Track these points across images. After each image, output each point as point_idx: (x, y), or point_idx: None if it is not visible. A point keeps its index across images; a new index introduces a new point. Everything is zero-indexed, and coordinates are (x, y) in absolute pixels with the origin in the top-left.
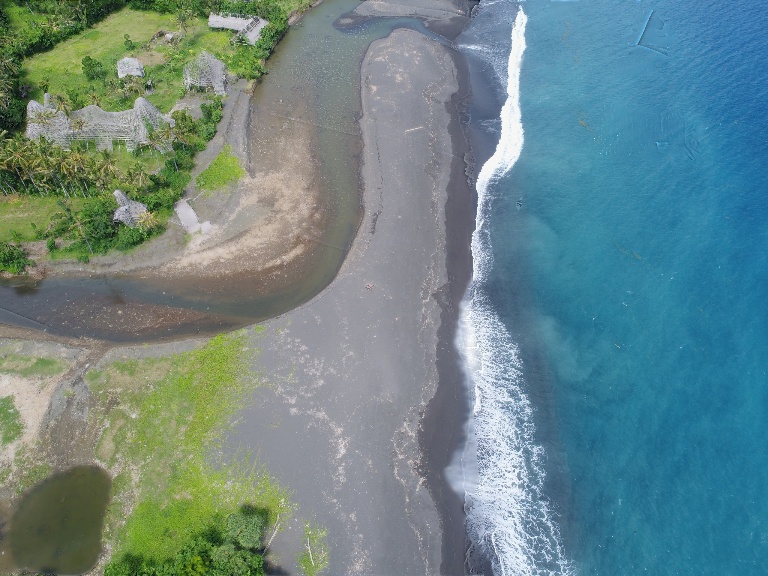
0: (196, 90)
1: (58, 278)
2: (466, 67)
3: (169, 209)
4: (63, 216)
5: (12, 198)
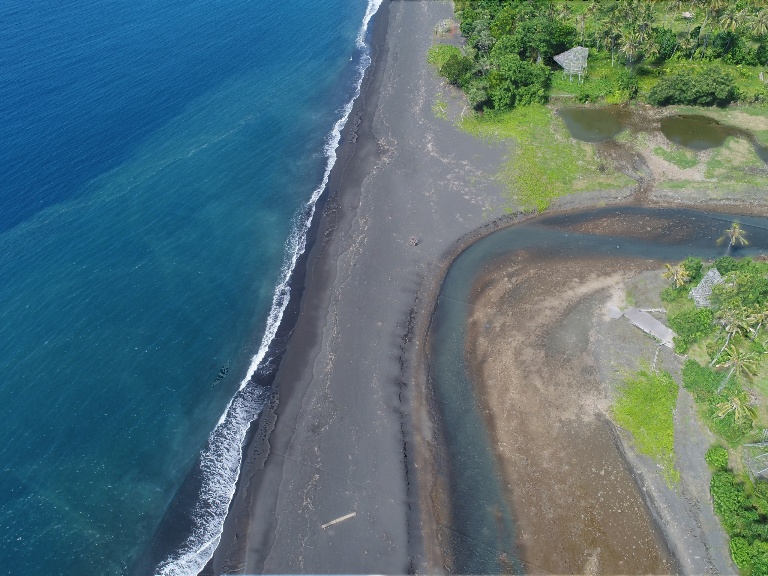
0: None
1: None
2: None
3: None
4: None
5: None
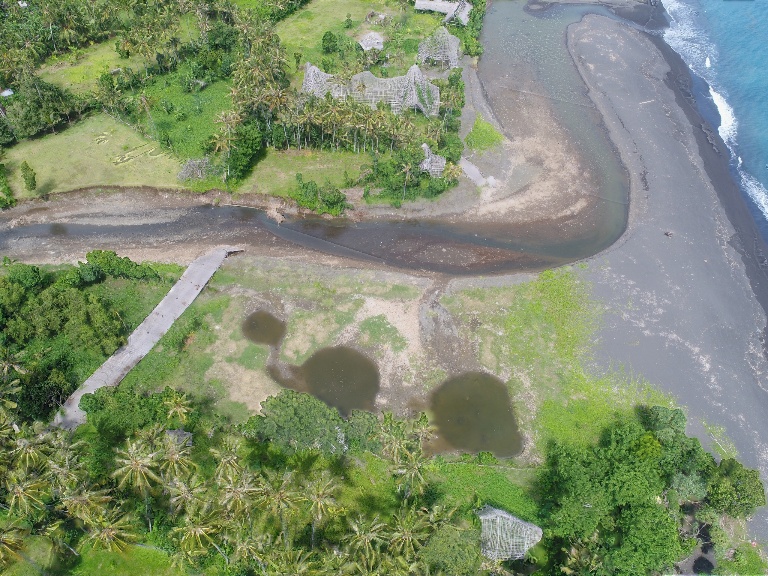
0: (431, 64)
1: (374, 221)
2: (668, 49)
3: (454, 164)
4: (369, 167)
5: (306, 152)
